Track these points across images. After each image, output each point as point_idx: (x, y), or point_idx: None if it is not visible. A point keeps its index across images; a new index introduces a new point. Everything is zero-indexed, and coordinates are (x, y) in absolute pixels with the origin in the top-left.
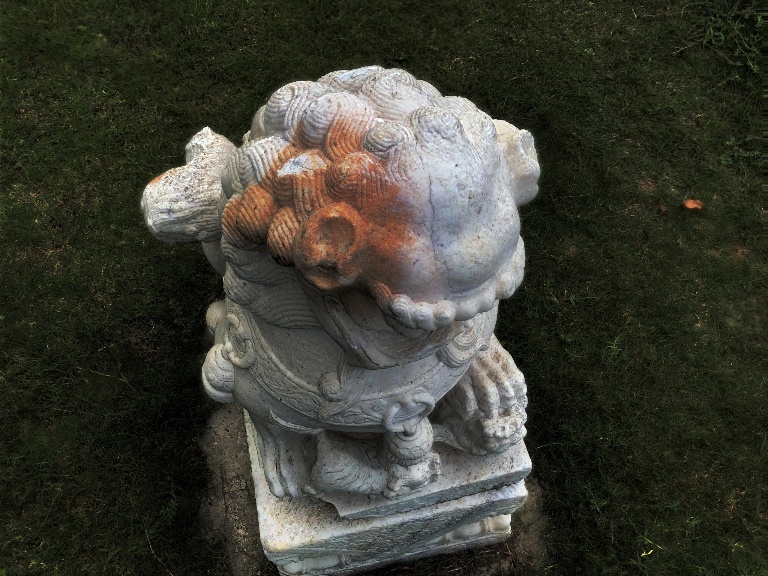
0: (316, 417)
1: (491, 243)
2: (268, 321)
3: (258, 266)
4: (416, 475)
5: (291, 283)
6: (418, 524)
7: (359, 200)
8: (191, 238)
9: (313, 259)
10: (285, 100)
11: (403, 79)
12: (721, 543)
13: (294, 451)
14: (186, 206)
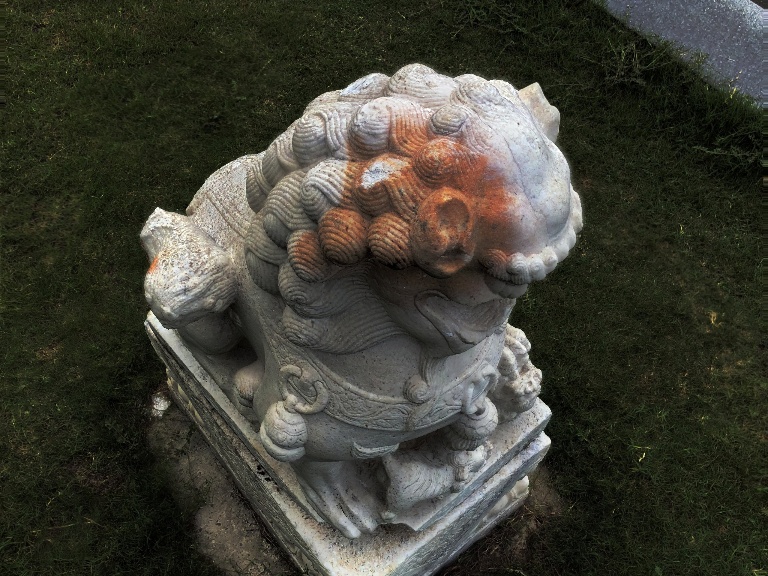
0: (405, 428)
1: (564, 183)
2: (340, 352)
3: (328, 297)
4: (477, 457)
5: (362, 302)
6: (471, 512)
7: (458, 180)
8: (206, 313)
9: (442, 246)
10: (318, 126)
11: (425, 70)
12: (691, 422)
13: (353, 488)
14: (198, 280)
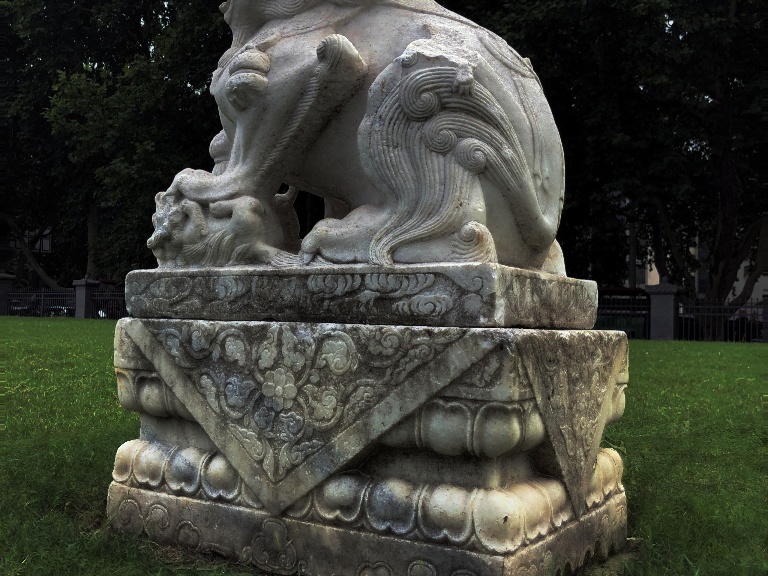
0: None
1: None
2: None
3: None
4: None
5: None
6: None
7: None
8: None
9: None
10: None
11: None
12: None
13: None
14: None
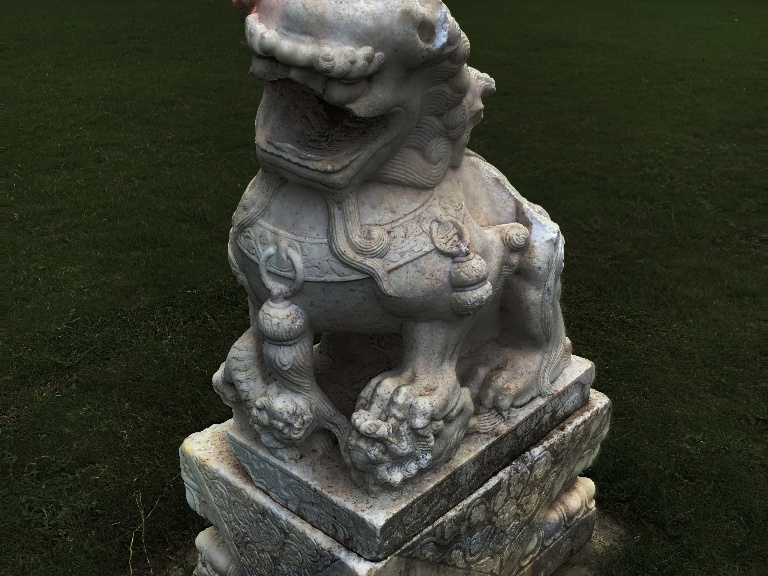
0: None
1: (327, 6)
2: None
3: None
4: (278, 403)
5: None
6: (276, 534)
7: None
8: None
9: None
10: None
11: None
12: None
13: None
14: None
